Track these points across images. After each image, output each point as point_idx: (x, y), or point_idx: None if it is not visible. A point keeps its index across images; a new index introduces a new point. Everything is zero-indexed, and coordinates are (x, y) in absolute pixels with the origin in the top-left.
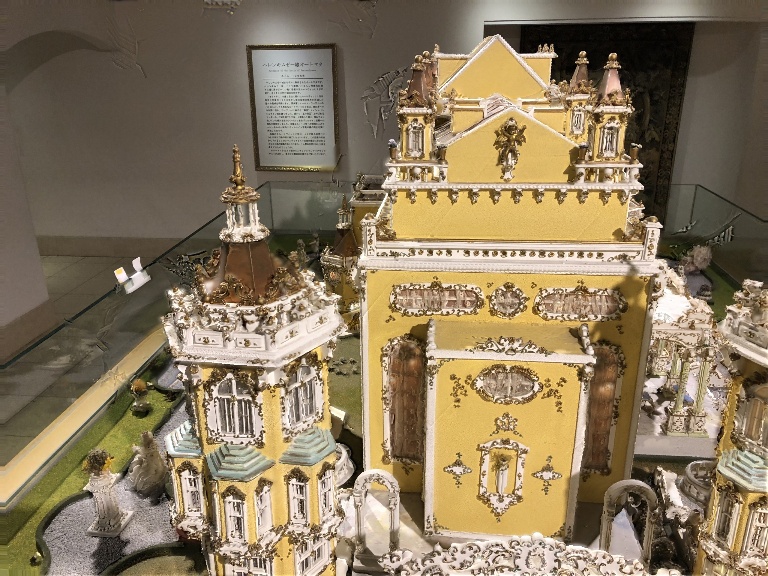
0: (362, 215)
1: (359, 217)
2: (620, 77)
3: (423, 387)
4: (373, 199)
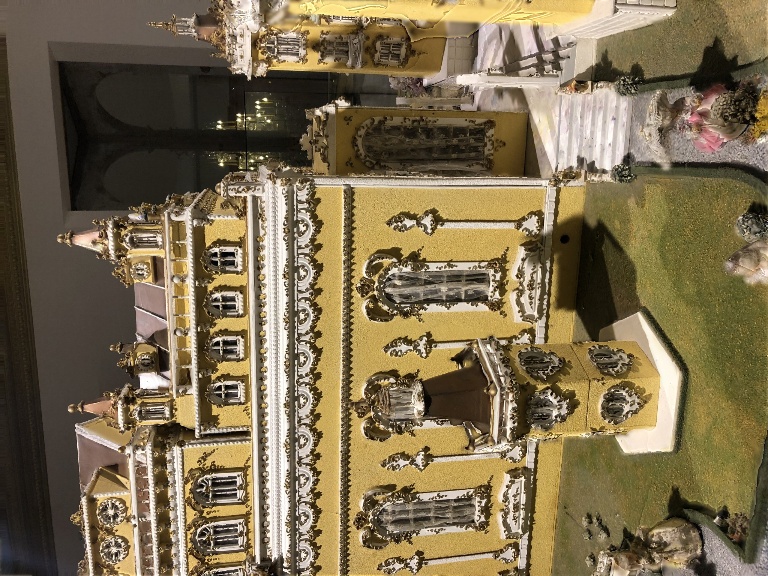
0: None
1: None
2: None
3: (381, 135)
4: None
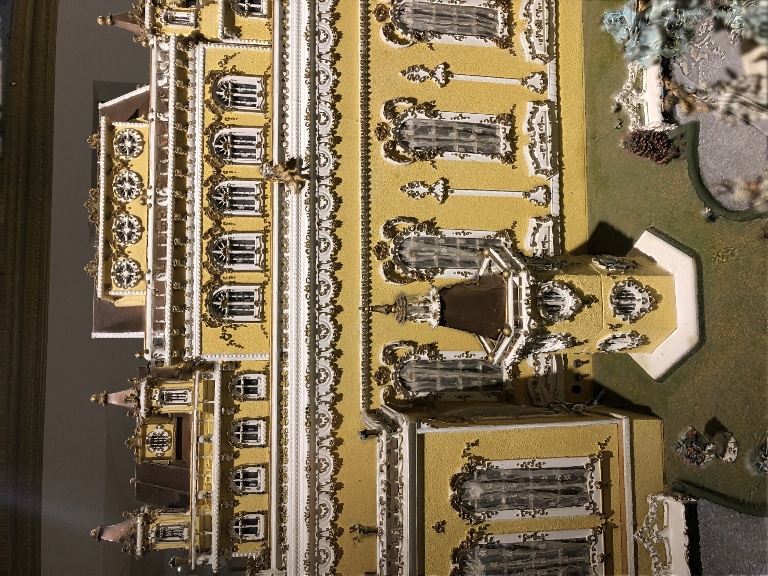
0: (433, 422)
1: (440, 424)
2: (194, 574)
3: None
4: (390, 425)
